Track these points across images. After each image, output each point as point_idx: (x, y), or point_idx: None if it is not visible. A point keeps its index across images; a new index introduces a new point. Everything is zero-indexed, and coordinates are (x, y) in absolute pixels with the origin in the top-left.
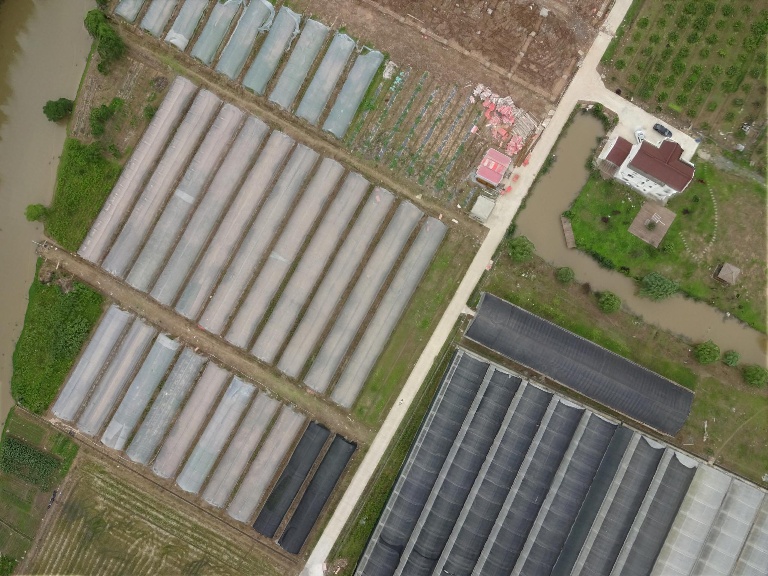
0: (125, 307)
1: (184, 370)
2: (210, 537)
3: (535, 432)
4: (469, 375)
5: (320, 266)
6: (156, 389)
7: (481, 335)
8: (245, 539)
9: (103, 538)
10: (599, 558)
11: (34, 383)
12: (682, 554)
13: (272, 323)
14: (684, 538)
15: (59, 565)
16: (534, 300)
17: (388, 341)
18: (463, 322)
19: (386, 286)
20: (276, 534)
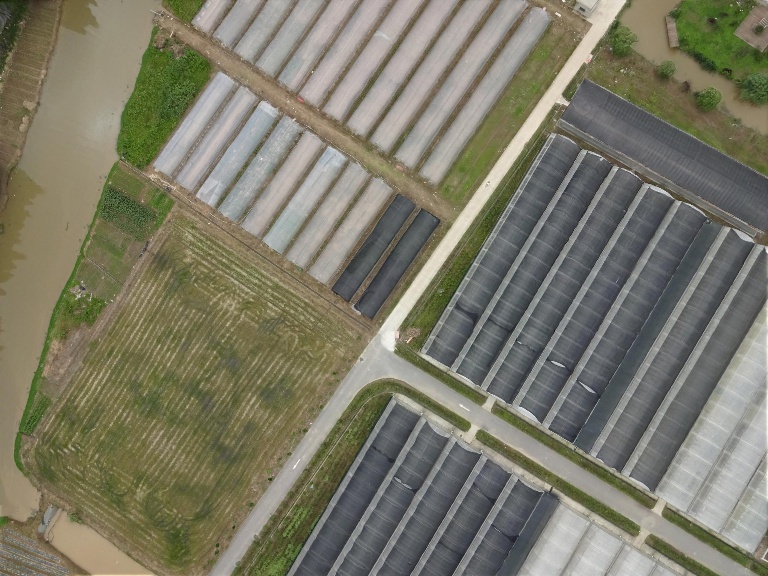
0: (230, 76)
1: (280, 138)
2: (289, 297)
3: (621, 218)
4: (560, 155)
5: (421, 49)
6: (252, 154)
7: (576, 118)
8: (322, 302)
9: (188, 289)
10: (676, 343)
11: (139, 140)
12: (763, 347)
13: (369, 99)
14: (767, 332)
15: (144, 311)
16: (631, 96)
17: (480, 125)
18: (557, 112)
19: (483, 72)
20: (353, 299)
